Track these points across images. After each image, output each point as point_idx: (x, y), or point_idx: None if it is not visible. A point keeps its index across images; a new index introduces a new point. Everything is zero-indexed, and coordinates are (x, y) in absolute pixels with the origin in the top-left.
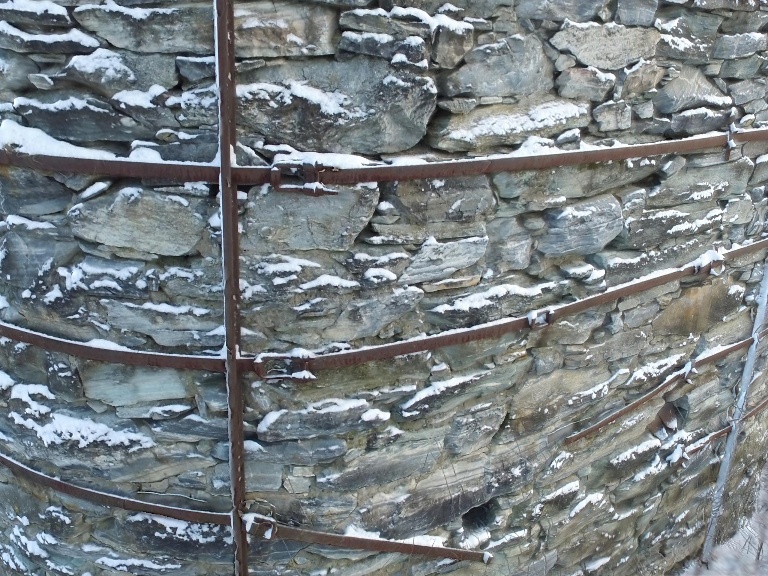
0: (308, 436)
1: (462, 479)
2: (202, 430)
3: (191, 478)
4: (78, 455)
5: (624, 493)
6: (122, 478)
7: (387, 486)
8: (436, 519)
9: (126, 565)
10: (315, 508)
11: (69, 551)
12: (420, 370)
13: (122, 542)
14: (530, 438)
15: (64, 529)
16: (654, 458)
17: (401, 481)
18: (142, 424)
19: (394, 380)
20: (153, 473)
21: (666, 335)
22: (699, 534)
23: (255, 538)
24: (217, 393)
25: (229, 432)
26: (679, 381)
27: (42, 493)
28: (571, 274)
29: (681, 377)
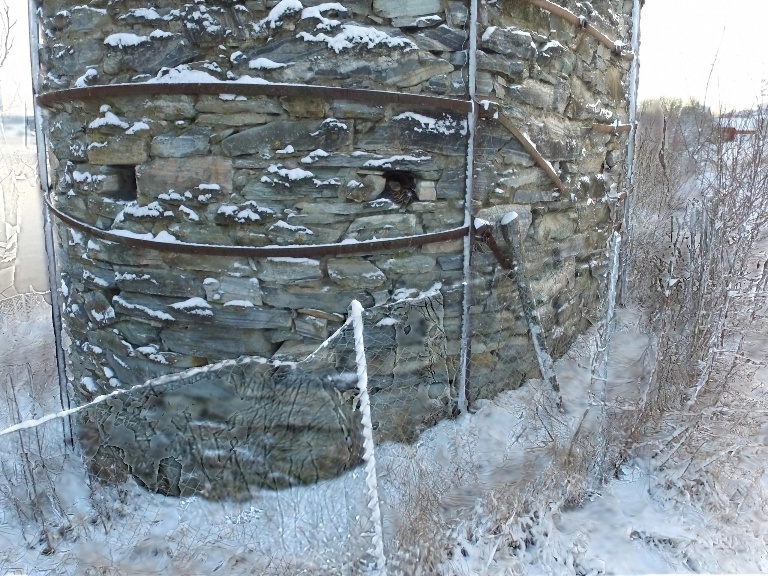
0: (508, 50)
1: (558, 131)
2: (450, 37)
3: (439, 80)
4: (365, 57)
5: (598, 212)
6: (393, 79)
7: (535, 112)
8: (552, 153)
9: (390, 162)
10: (510, 111)
11: (341, 159)
12: (547, 27)
13: (387, 141)
14: (575, 123)
15: (341, 135)
16: (605, 194)
17: (539, 113)
18: (407, 35)
19: (536, 31)
20: (414, 76)
21: (607, 92)
22: (618, 282)
23: (478, 132)
24: (462, 5)
25: (475, 30)
26: (611, 135)
27: (320, 107)
28: (588, 4)
29: (613, 131)
